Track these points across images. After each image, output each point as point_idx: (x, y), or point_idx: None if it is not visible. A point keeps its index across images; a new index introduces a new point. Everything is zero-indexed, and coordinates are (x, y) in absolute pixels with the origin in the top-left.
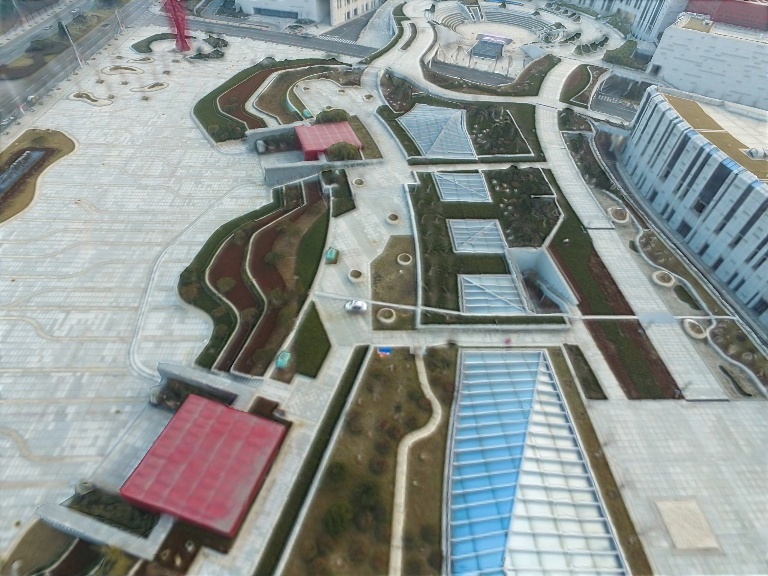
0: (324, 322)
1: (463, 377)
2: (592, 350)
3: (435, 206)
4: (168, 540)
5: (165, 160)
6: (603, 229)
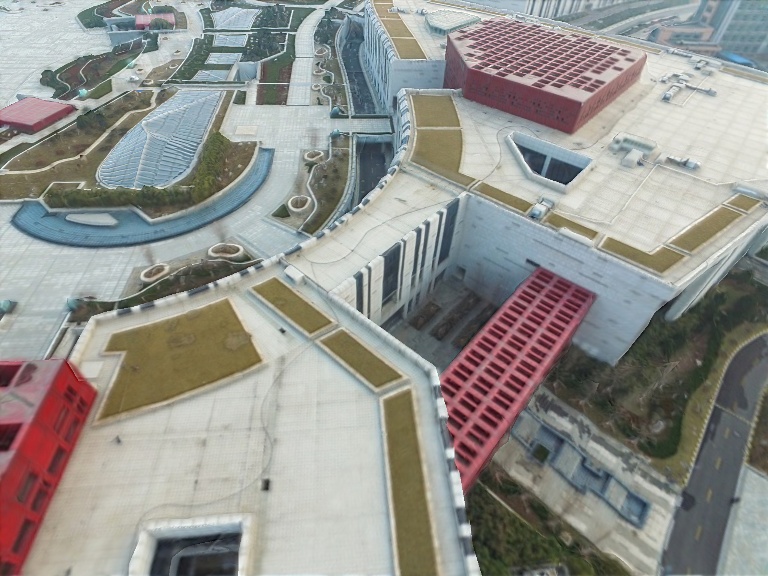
0: (113, 85)
1: (173, 97)
2: (253, 92)
3: (206, 48)
4: (6, 131)
5: (50, 37)
6: (306, 58)
